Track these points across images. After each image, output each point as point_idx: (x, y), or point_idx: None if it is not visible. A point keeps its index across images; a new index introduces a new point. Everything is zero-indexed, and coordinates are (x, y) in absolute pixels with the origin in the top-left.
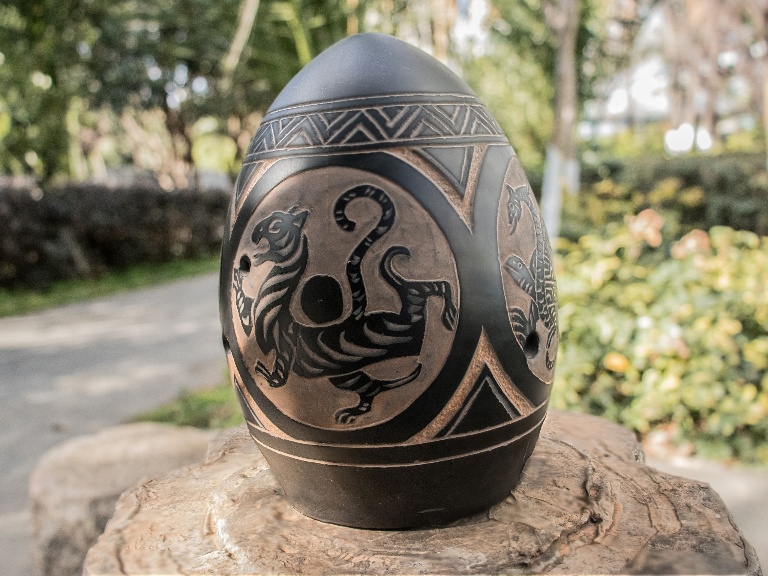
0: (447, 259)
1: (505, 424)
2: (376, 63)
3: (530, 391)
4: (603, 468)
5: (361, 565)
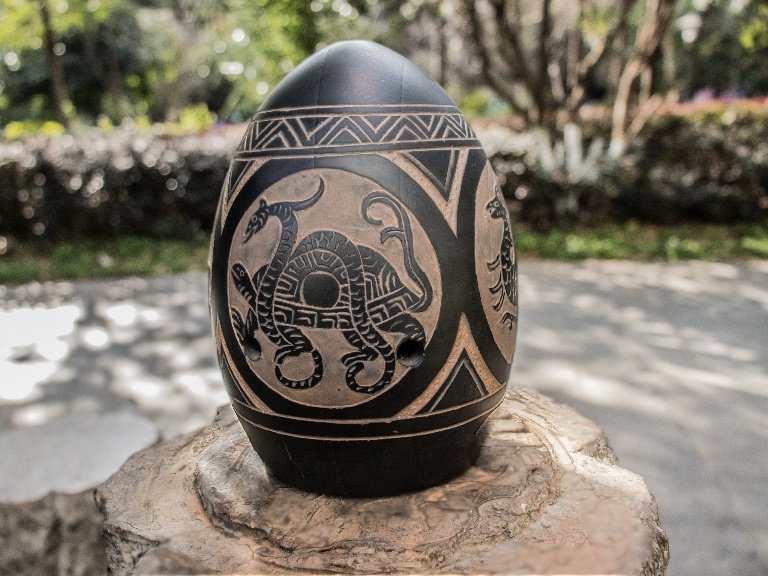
0: (212, 251)
1: (246, 405)
2: None
3: (260, 391)
4: (427, 572)
5: (229, 448)
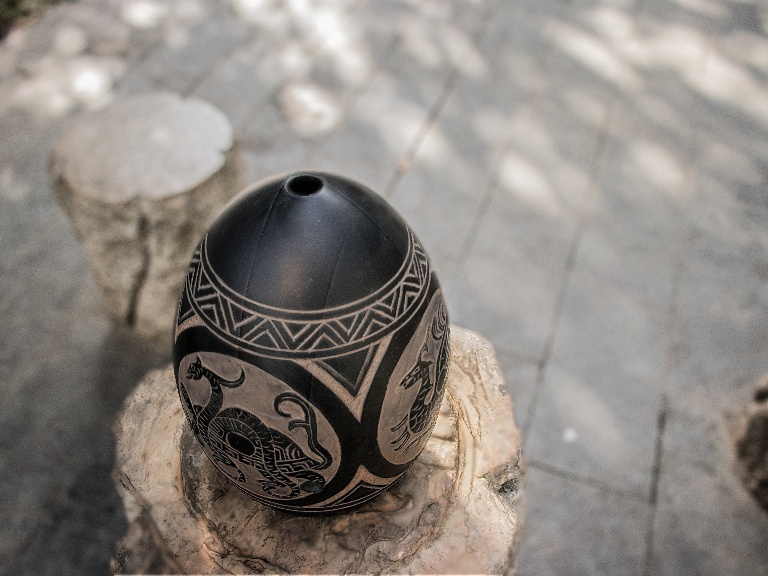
0: None
1: None
2: (230, 210)
3: None
4: None
5: None
